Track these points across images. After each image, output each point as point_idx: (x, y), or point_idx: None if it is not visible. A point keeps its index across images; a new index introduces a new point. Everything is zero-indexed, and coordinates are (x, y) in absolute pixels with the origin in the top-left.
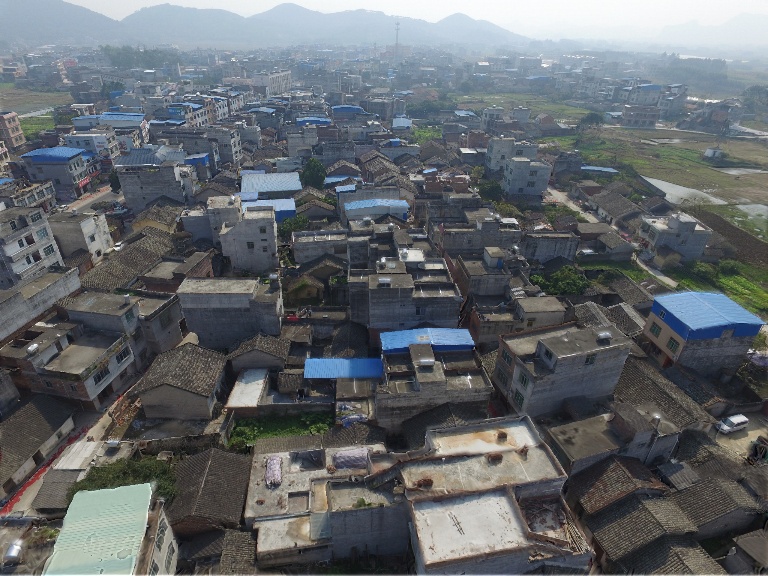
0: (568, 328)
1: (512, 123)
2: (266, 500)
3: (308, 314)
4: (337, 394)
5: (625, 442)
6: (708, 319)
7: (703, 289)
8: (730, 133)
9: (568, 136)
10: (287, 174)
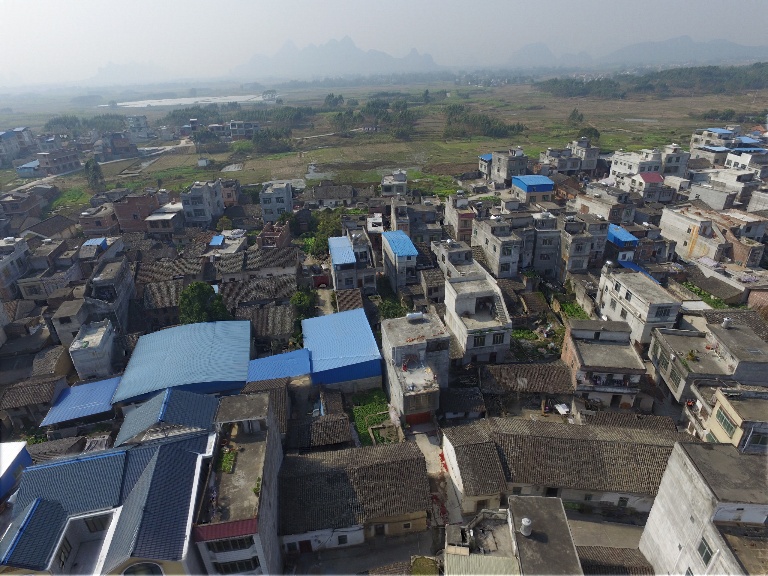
0: (585, 196)
1: (30, 196)
2: (765, 280)
3: (592, 285)
4: (667, 271)
5: (643, 206)
6: (545, 179)
7: (443, 199)
8: (143, 154)
9: (64, 195)
10: (166, 339)
